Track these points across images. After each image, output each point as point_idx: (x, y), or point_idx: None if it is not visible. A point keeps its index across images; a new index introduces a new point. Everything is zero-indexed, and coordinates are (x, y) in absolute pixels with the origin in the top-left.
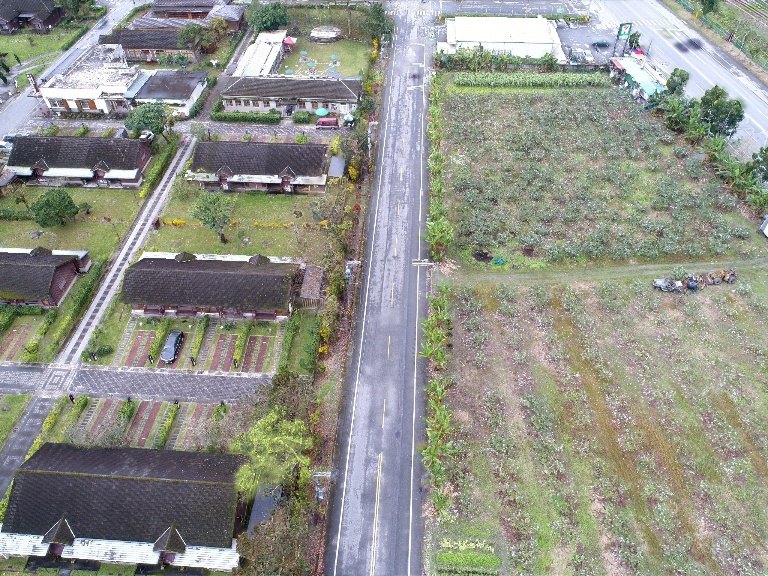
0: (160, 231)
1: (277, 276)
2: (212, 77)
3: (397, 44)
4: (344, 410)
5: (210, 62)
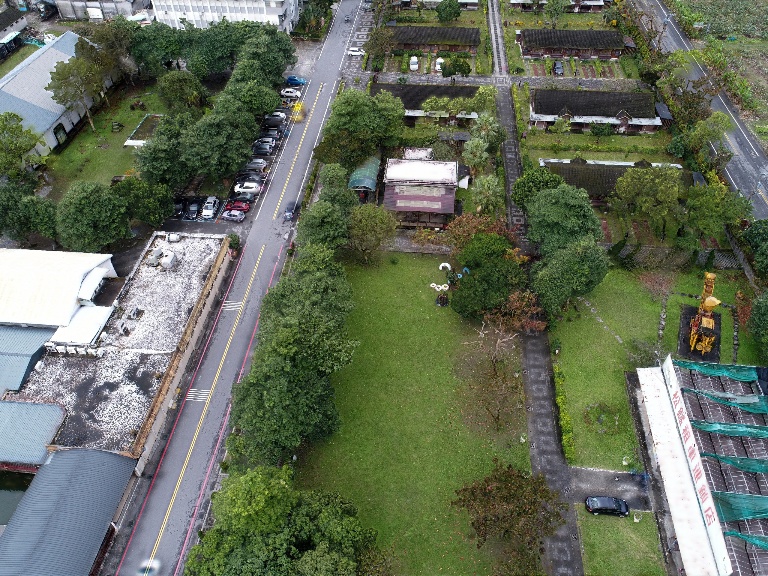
0: (508, 28)
1: (615, 31)
2: None
3: None
4: None
5: None
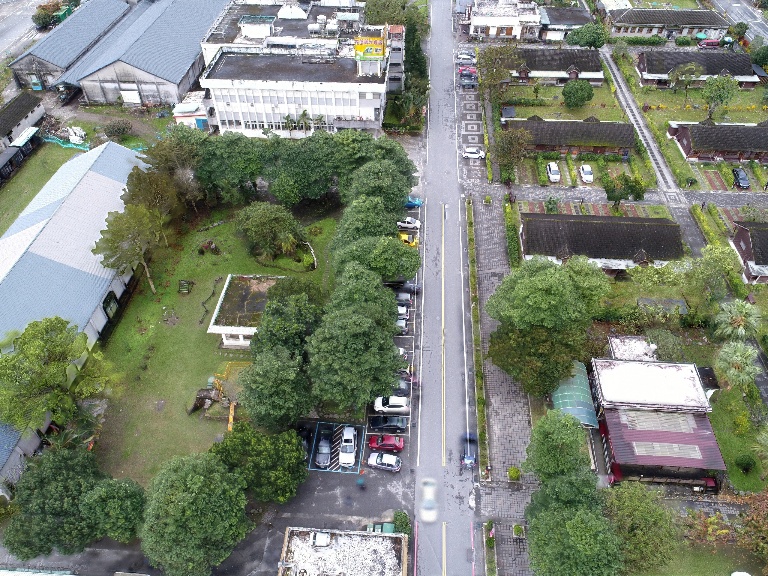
0: (649, 113)
1: None
2: None
3: None
4: None
5: (566, 3)
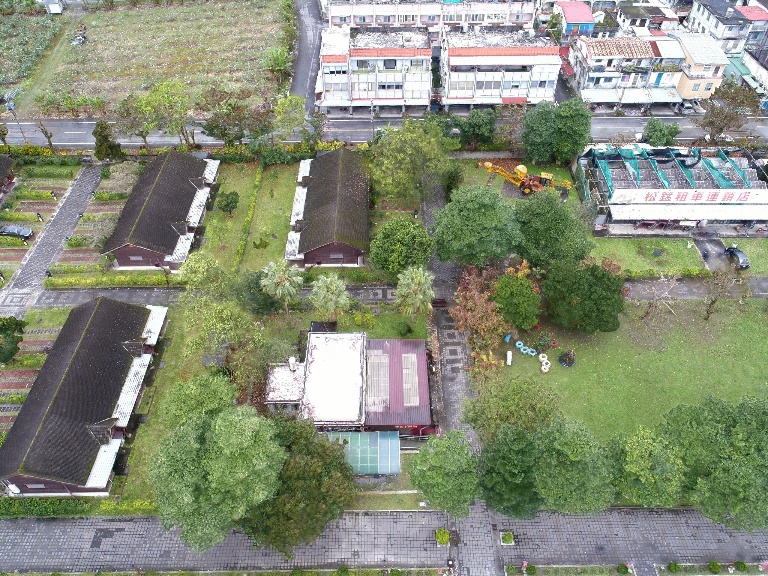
0: None
1: None
2: None
3: None
4: (121, 147)
5: None
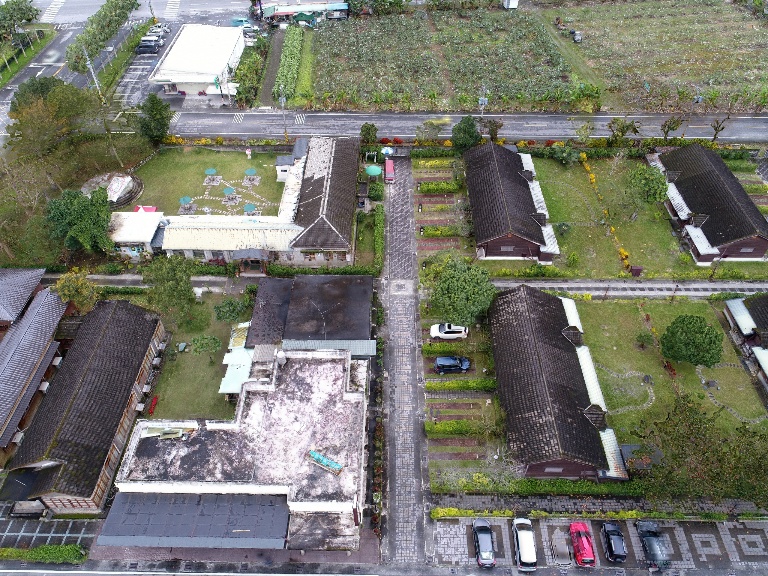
0: None
1: None
2: (255, 287)
3: (169, 132)
4: (765, 142)
5: None
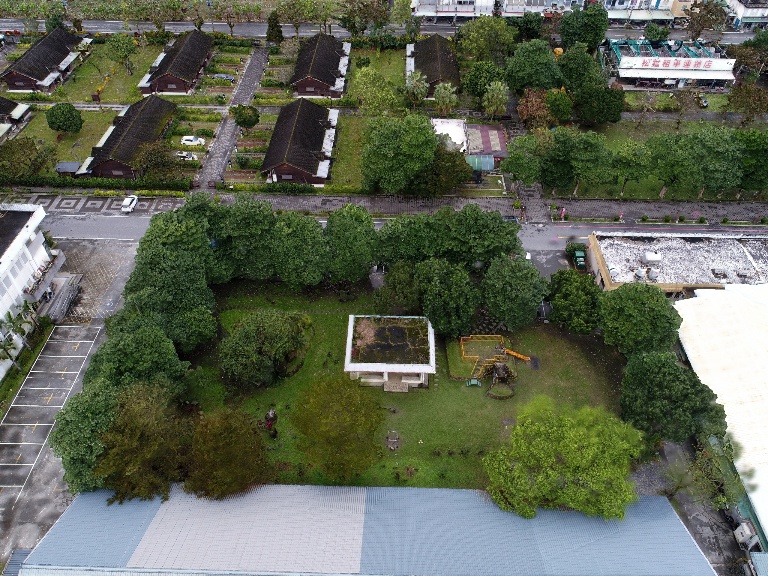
0: (102, 99)
1: (194, 33)
2: None
3: None
4: None
5: None
